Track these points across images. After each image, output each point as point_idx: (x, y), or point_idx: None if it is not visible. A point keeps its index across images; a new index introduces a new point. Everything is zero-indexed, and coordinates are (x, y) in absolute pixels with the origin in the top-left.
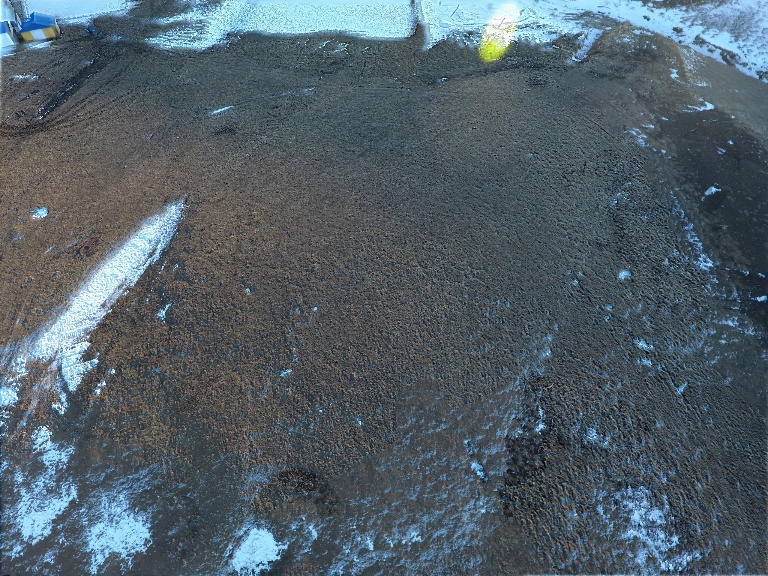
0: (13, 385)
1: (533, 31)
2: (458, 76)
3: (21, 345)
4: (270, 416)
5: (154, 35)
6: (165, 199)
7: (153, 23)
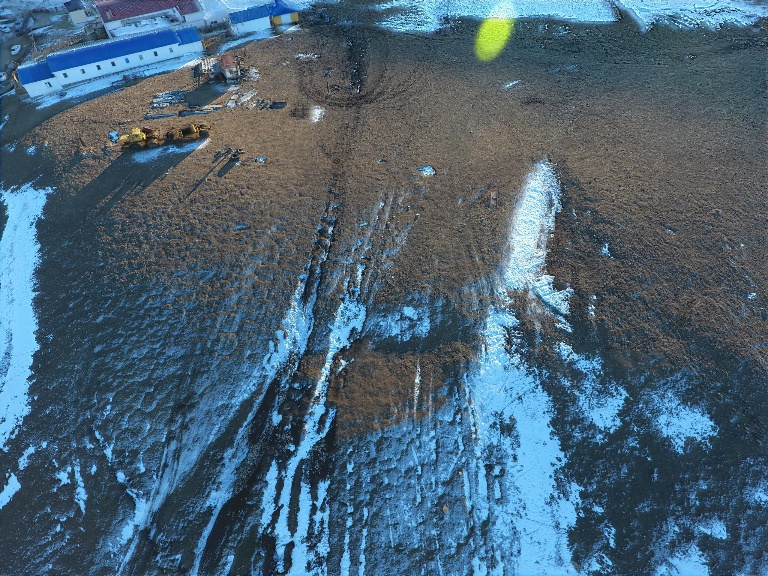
0: (508, 310)
1: (732, 15)
2: (703, 54)
3: (494, 278)
4: (762, 329)
5: (382, 20)
6: (531, 158)
7: (373, 9)
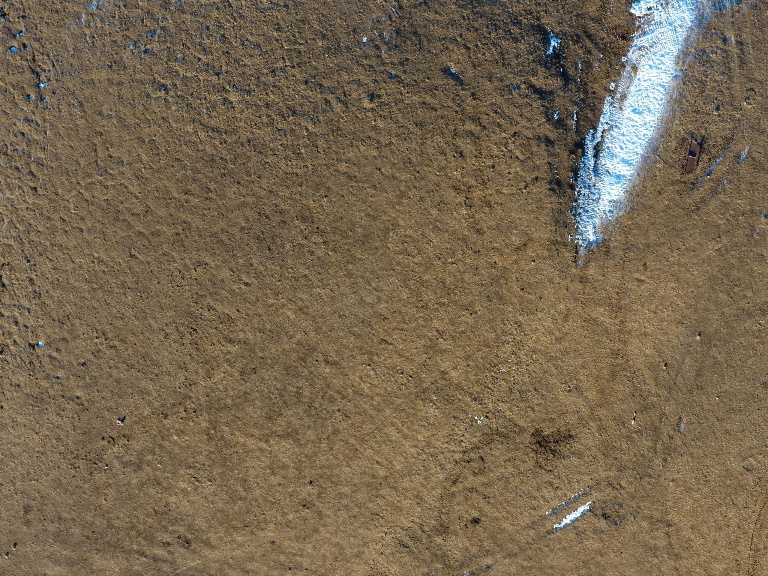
0: None
1: None
2: None
3: (713, 8)
4: None
5: None
6: (610, 253)
7: None
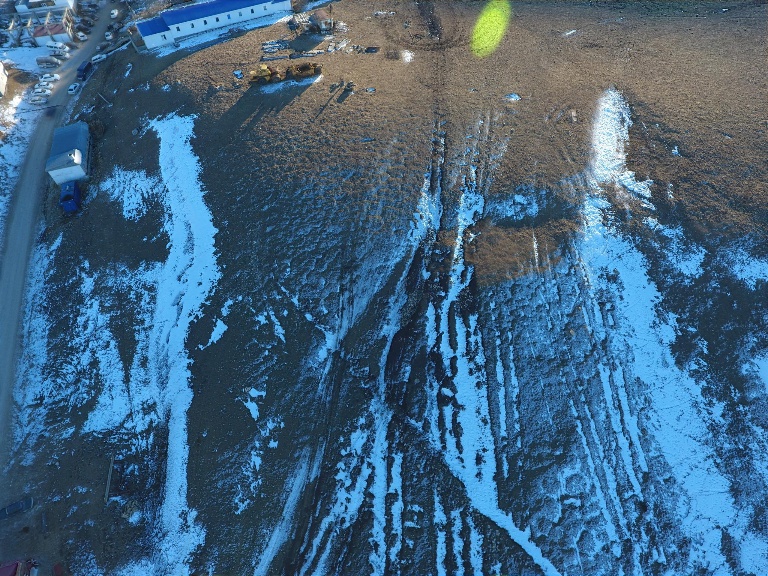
0: (600, 196)
1: None
2: (735, 7)
3: (586, 174)
4: None
5: None
6: (601, 87)
7: None
